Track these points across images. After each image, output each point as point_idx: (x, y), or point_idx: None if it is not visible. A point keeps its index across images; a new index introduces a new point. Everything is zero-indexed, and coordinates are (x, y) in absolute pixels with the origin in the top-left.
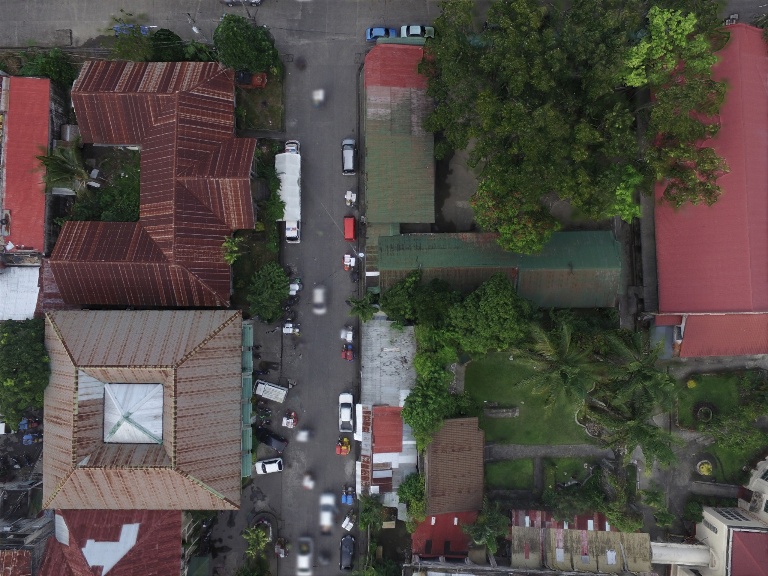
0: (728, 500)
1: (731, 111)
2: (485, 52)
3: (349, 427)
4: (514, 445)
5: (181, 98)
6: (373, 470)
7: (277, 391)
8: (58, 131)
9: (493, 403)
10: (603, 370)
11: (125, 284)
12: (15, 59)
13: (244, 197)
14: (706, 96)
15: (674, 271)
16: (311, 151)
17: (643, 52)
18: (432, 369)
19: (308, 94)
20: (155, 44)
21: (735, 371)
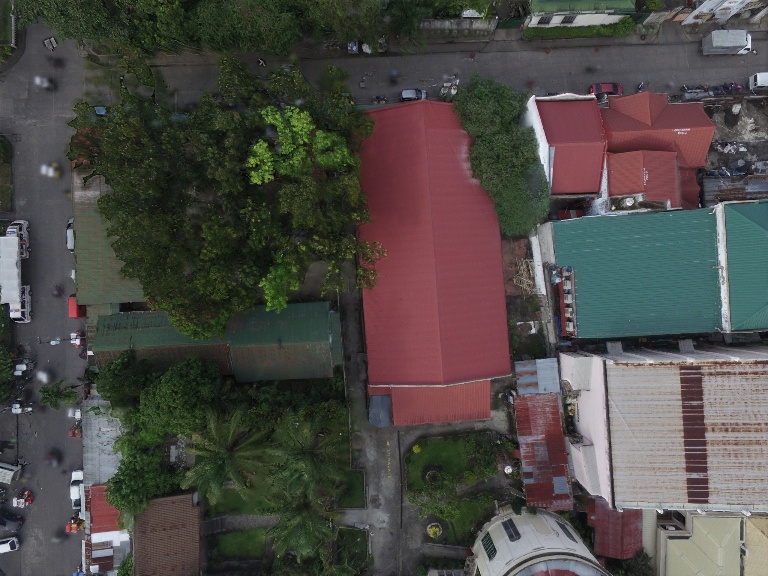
0: (455, 562)
1: (420, 186)
2: None
3: None
4: (246, 515)
5: None
6: (92, 550)
7: (4, 472)
8: None
9: None
10: (262, 457)
11: None
12: None
13: None
14: (340, 188)
15: (379, 343)
16: (41, 230)
17: None
18: (129, 453)
19: (37, 173)
20: None
21: (463, 433)
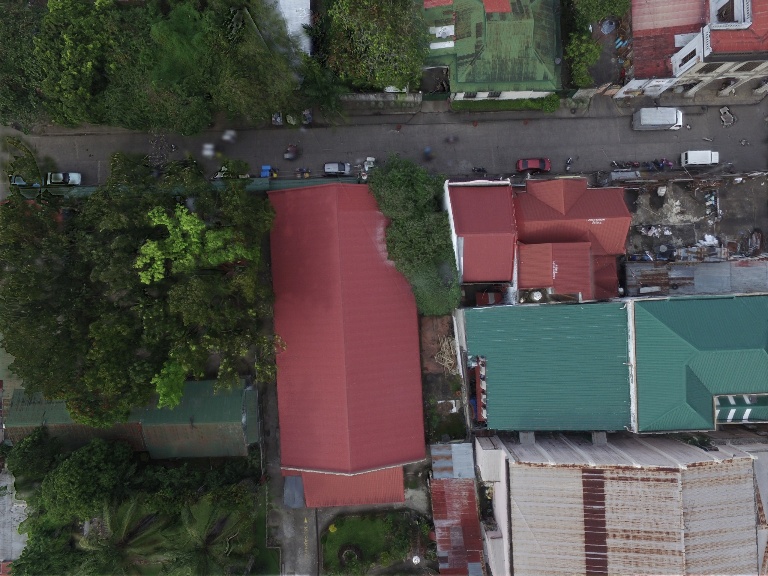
0: None
1: (331, 270)
2: None
3: None
4: None
5: None
6: None
7: None
8: None
9: None
10: (154, 553)
11: None
12: None
13: None
14: (232, 286)
15: (291, 425)
16: None
17: (150, 251)
18: (33, 535)
19: None
20: None
21: (381, 512)
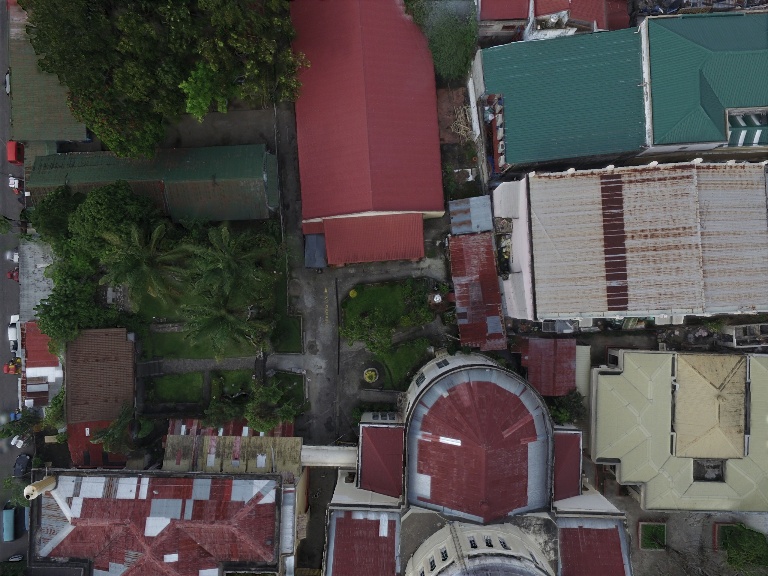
0: (391, 405)
1: (351, 16)
2: None
3: None
4: (184, 359)
5: None
6: (27, 384)
7: None
8: None
9: (162, 319)
10: (183, 263)
11: None
12: None
13: None
14: None
15: (313, 178)
16: None
17: None
18: (59, 278)
19: None
20: None
21: (400, 280)
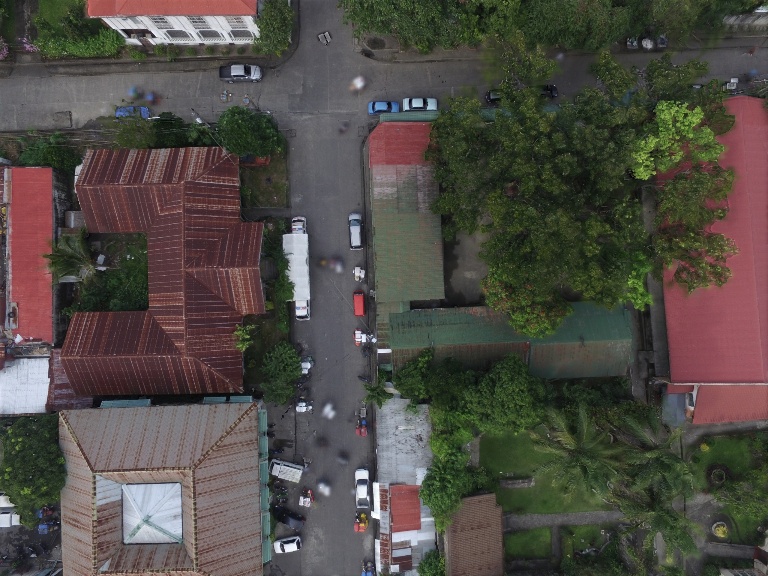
0: (744, 561)
1: (736, 182)
2: (494, 148)
3: (366, 503)
4: (531, 514)
5: (187, 188)
6: (392, 549)
7: (293, 471)
8: (62, 218)
9: (509, 473)
10: (621, 456)
11: (137, 376)
12: (15, 143)
13: (254, 285)
14: (714, 184)
15: (685, 340)
16: (317, 226)
17: (651, 146)
18: (449, 451)
19: (312, 169)
20: (158, 130)
21: (747, 432)
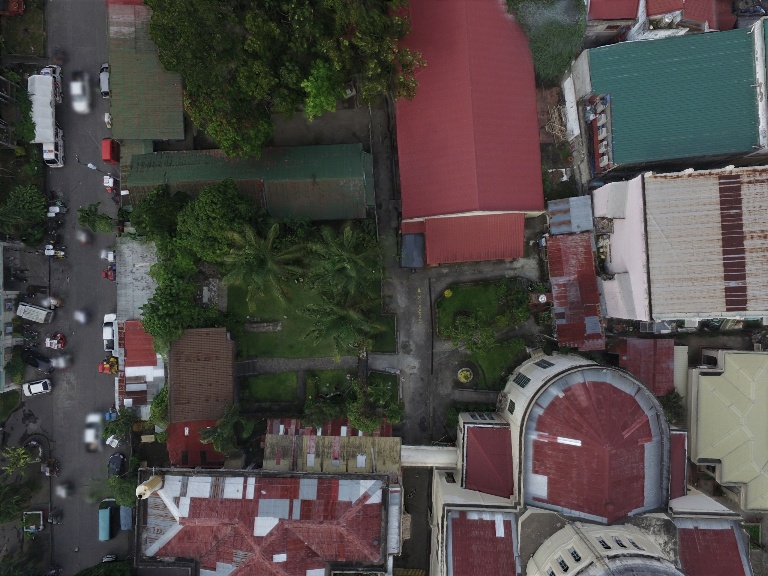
0: (486, 405)
1: (456, 15)
2: None
3: None
4: (278, 359)
5: None
6: (126, 383)
7: (37, 312)
8: None
9: (256, 318)
10: (302, 262)
11: None
12: None
13: None
14: None
15: (414, 177)
16: (73, 76)
17: None
18: (165, 277)
19: (70, 20)
20: None
21: (494, 280)
